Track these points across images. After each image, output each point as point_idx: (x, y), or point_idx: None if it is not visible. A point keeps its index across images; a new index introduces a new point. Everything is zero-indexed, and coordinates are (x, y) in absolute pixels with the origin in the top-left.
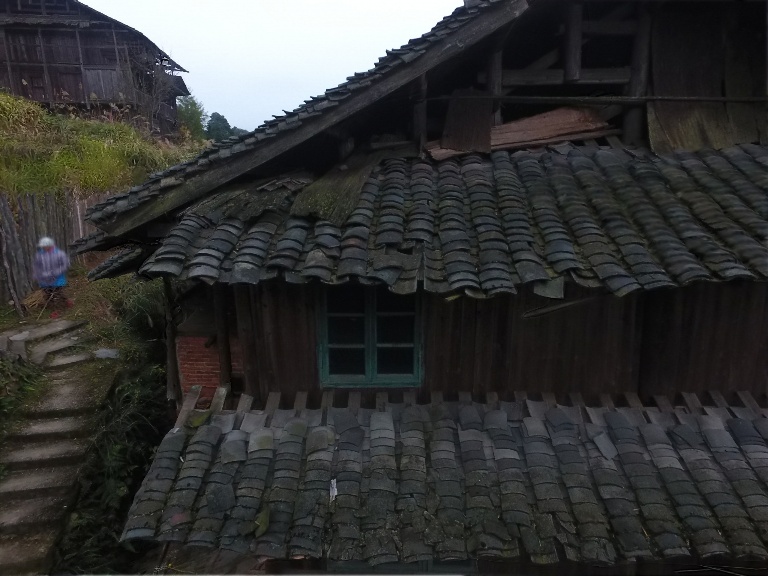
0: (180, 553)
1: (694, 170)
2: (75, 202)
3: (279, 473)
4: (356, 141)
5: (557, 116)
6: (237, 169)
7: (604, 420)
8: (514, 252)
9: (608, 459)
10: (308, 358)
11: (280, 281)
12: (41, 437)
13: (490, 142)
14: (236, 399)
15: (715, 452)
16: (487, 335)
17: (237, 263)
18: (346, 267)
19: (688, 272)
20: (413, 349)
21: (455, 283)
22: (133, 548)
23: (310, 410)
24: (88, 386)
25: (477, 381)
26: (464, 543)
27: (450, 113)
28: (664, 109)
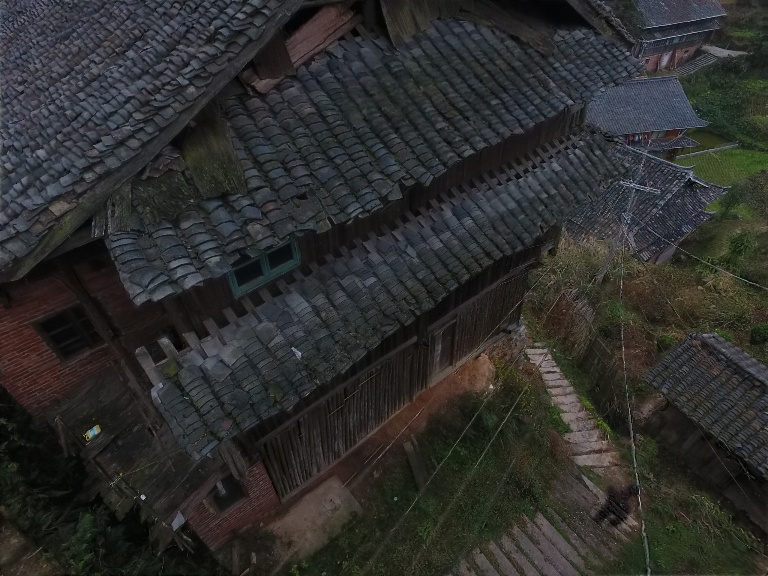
0: (121, 463)
1: (421, 61)
2: None
3: (260, 364)
4: None
5: (322, 16)
6: (128, 172)
7: (403, 236)
8: (367, 175)
9: (414, 258)
10: (221, 285)
11: None
12: None
13: (291, 61)
14: (121, 338)
15: (452, 230)
16: None
17: (207, 260)
18: (282, 229)
19: (450, 160)
20: (290, 244)
21: (352, 214)
22: (63, 491)
23: (242, 317)
24: None
25: (332, 244)
26: (376, 336)
27: None
28: (390, 1)
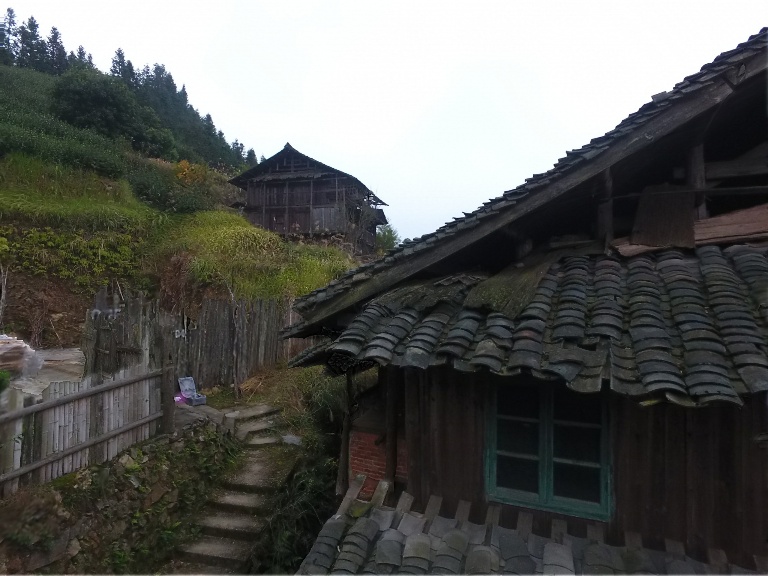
0: None
1: None
2: (290, 307)
3: None
4: (534, 242)
5: None
6: (418, 265)
7: None
8: (735, 354)
9: None
10: (474, 463)
11: (448, 368)
12: (231, 508)
13: (693, 236)
14: None
15: None
16: (704, 467)
17: (409, 348)
18: (518, 358)
19: None
20: (599, 471)
21: (652, 384)
22: None
23: (473, 524)
24: (273, 467)
25: (692, 529)
26: None
27: (641, 210)
28: None
